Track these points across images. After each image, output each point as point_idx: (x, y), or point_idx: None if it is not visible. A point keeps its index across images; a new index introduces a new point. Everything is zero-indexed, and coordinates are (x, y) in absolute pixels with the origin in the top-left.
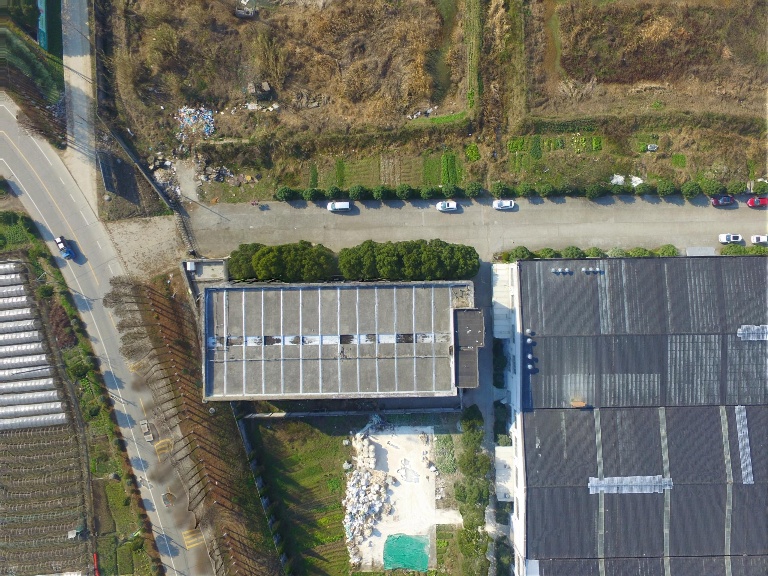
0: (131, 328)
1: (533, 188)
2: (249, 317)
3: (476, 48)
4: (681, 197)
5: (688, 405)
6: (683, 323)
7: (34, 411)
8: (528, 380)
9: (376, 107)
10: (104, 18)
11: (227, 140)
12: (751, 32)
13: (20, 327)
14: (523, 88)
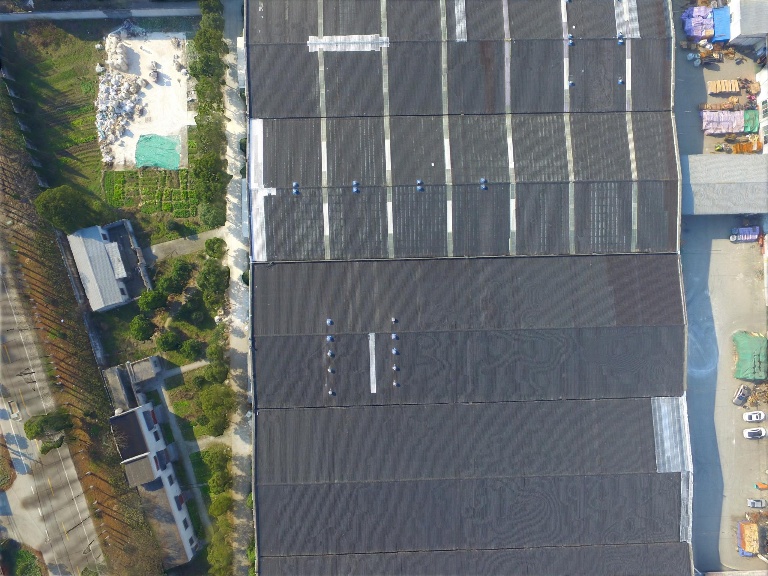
0: None
1: None
2: None
3: None
4: None
5: None
6: None
7: None
8: None
9: None
10: None
11: None
12: None
13: None
14: None
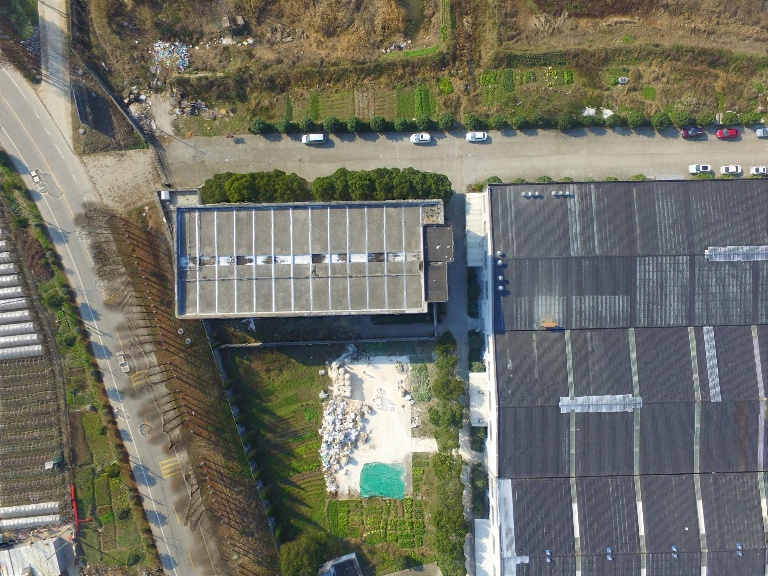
0: (107, 259)
1: (506, 120)
2: (221, 237)
3: None
4: (651, 129)
5: (657, 326)
6: (651, 245)
7: (10, 343)
8: (499, 302)
9: (350, 41)
10: None
11: (202, 73)
12: None
13: None
14: (495, 22)
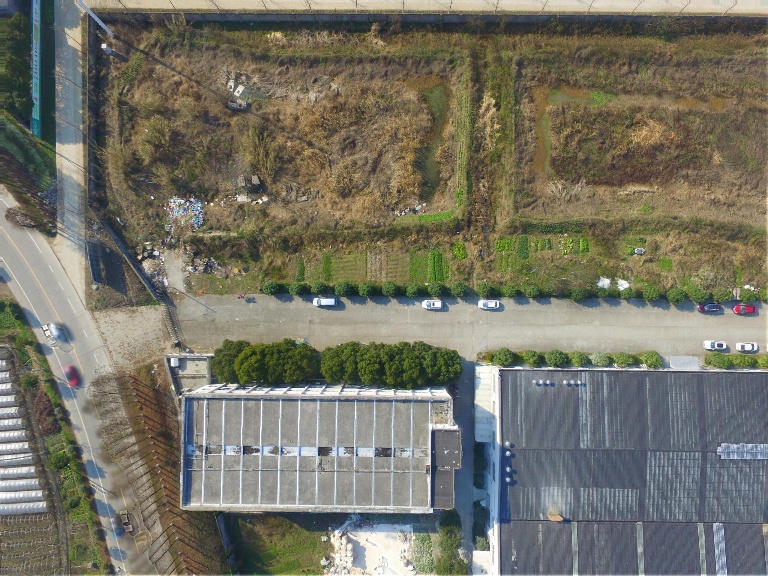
0: (114, 419)
1: (519, 288)
2: (229, 426)
3: (466, 147)
4: (667, 302)
5: (666, 521)
6: (663, 439)
7: (15, 499)
8: (506, 491)
9: (365, 203)
10: (98, 108)
11: (215, 233)
12: (742, 138)
13: (4, 414)
14: (512, 189)
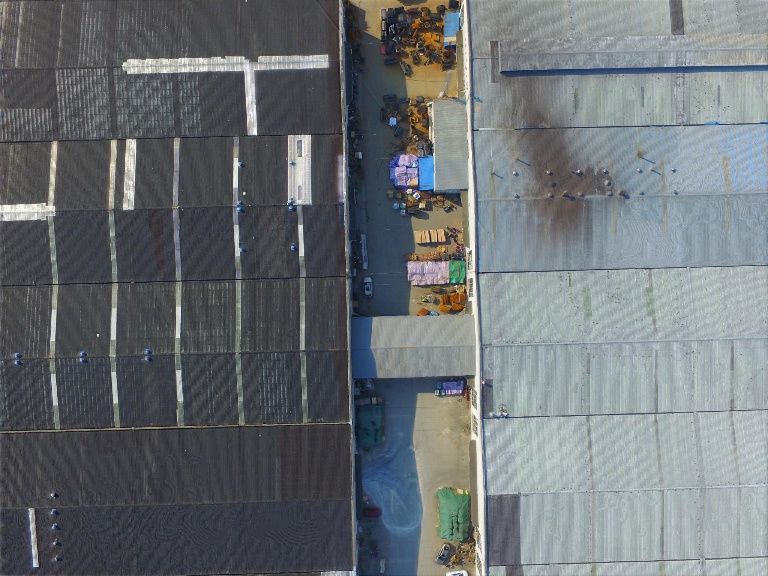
0: None
1: None
2: None
3: None
4: None
5: (81, 139)
6: (71, 58)
7: None
8: None
9: None
10: None
11: None
12: None
13: None
14: None
